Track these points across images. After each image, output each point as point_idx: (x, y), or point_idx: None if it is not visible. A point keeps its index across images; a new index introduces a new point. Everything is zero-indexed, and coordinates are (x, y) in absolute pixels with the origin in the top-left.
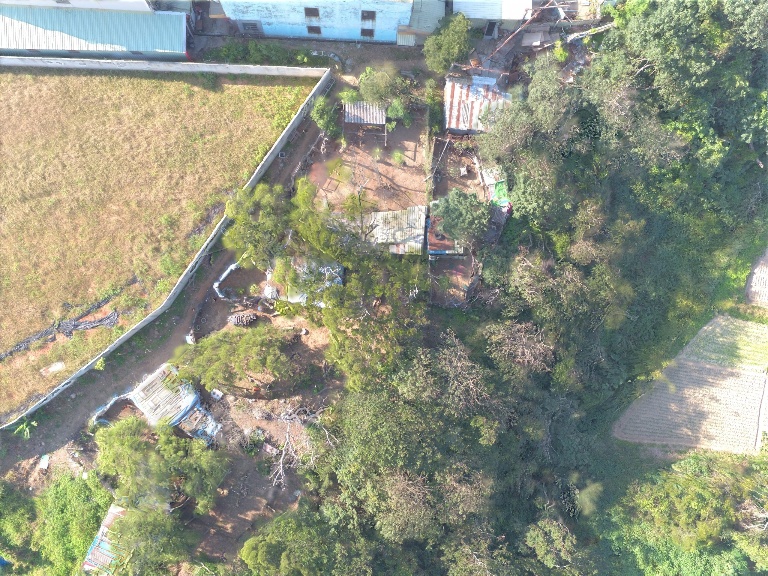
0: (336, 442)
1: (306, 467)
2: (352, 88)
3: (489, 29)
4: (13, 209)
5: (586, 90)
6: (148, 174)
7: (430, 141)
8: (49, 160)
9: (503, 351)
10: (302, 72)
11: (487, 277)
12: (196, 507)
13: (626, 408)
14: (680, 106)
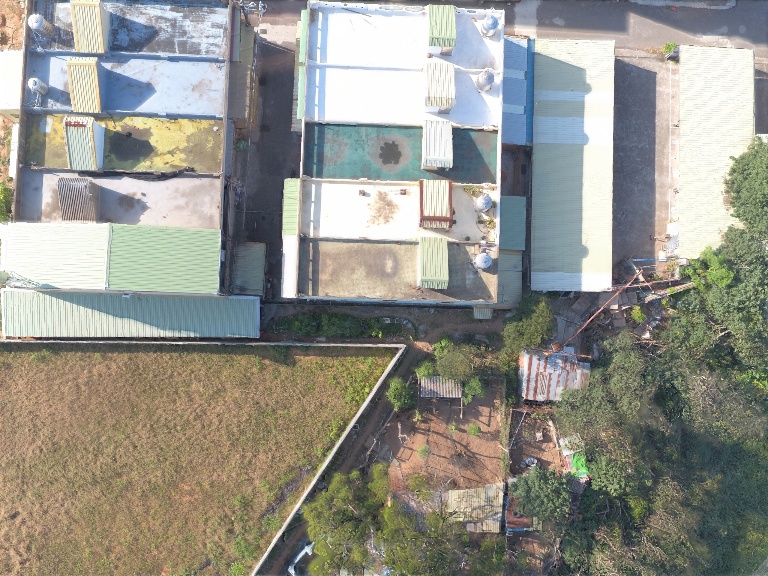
0: None
1: None
2: (426, 354)
3: (566, 293)
4: (84, 494)
5: (663, 346)
6: (220, 453)
7: (506, 411)
8: (120, 441)
9: None
10: (376, 346)
11: (567, 559)
12: None
13: None
14: None
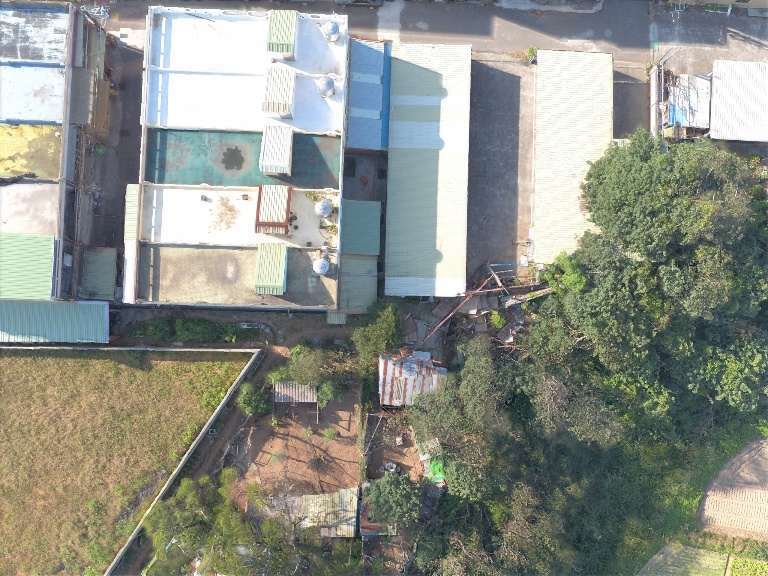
0: None
1: None
2: (284, 359)
3: (424, 298)
4: None
5: (526, 351)
6: (75, 457)
7: (363, 416)
8: None
9: None
10: None
11: (420, 564)
12: None
13: None
14: None
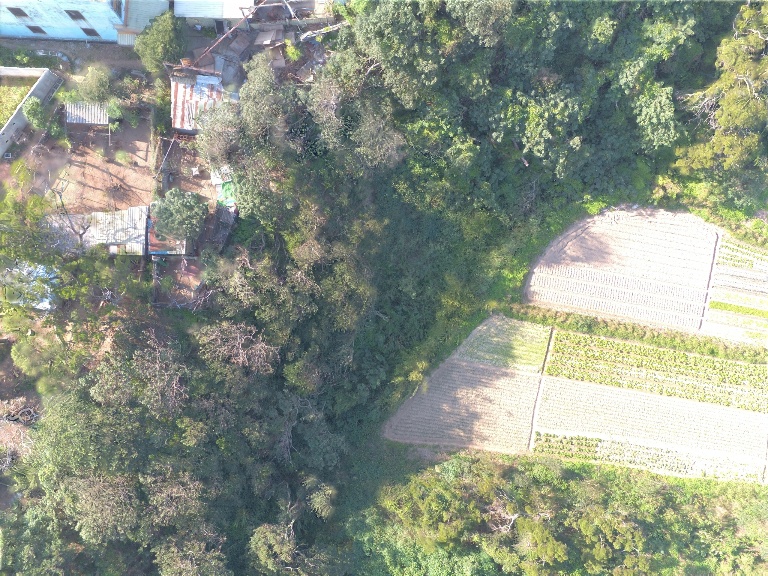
0: (31, 443)
1: (8, 468)
2: None
3: (219, 28)
4: None
5: None
6: None
7: (157, 141)
8: None
9: (217, 352)
10: (24, 72)
11: (204, 278)
12: None
13: (395, 408)
14: (426, 105)
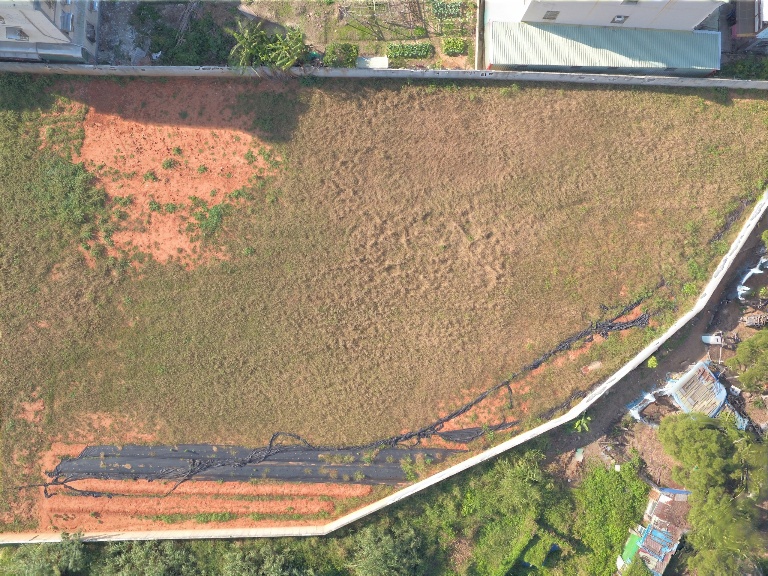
0: None
1: None
2: None
3: None
4: (552, 217)
5: None
6: (671, 183)
7: None
8: (580, 170)
9: None
10: None
11: None
12: (747, 497)
13: None
14: None
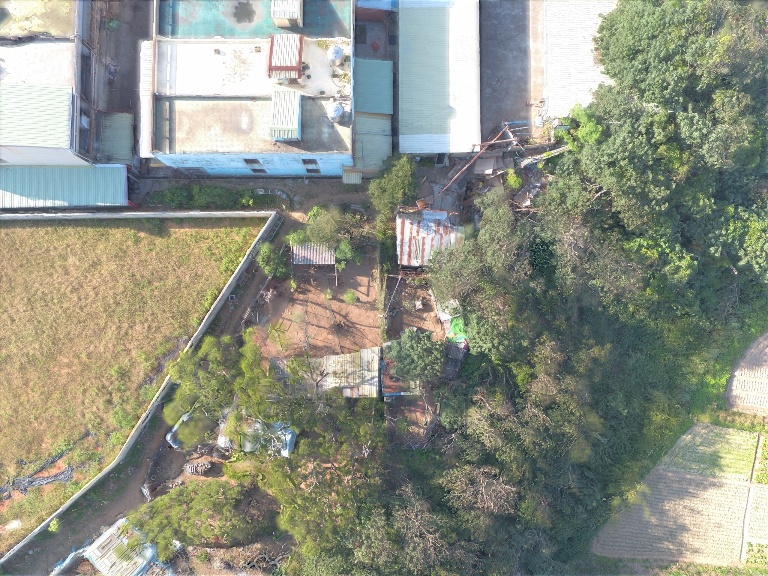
0: None
1: None
2: (301, 225)
3: (439, 159)
4: None
5: (544, 213)
6: (97, 325)
7: (382, 278)
8: None
9: (461, 498)
10: (248, 215)
11: (443, 421)
12: None
13: (603, 523)
14: (644, 223)
